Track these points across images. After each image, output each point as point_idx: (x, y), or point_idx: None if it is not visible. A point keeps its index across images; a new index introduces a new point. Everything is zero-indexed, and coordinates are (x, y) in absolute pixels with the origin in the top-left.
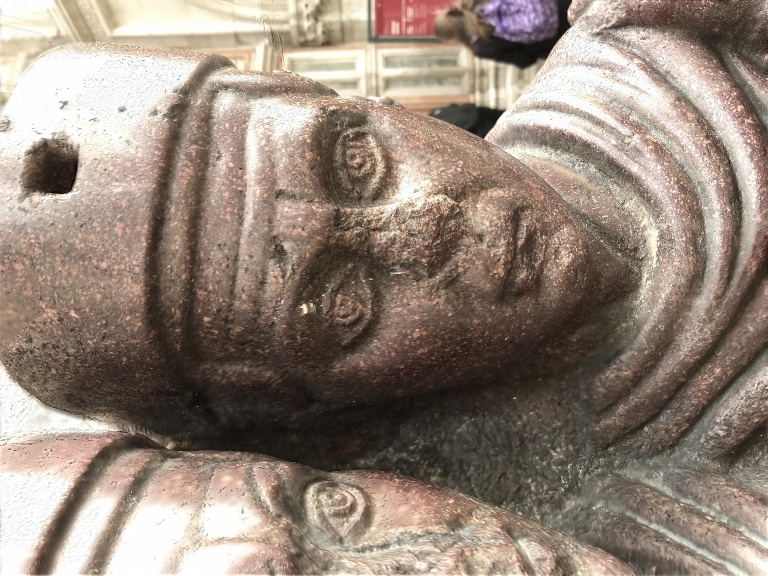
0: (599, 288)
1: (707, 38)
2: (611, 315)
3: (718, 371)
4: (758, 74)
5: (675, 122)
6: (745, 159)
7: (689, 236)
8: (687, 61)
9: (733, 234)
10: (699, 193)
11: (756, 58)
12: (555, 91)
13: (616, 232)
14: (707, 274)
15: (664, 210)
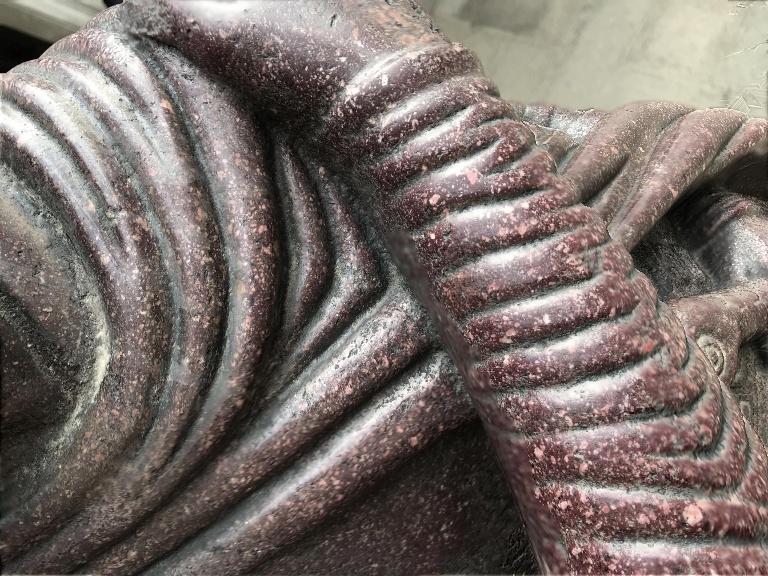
0: (0, 415)
1: (262, 115)
2: (11, 453)
3: (133, 555)
4: (303, 188)
5: (178, 216)
6: (245, 299)
7: (142, 380)
8: (225, 136)
9: (197, 394)
10: (177, 324)
11: (310, 166)
12: (44, 91)
13: (56, 337)
14: (151, 435)
15: (123, 333)
